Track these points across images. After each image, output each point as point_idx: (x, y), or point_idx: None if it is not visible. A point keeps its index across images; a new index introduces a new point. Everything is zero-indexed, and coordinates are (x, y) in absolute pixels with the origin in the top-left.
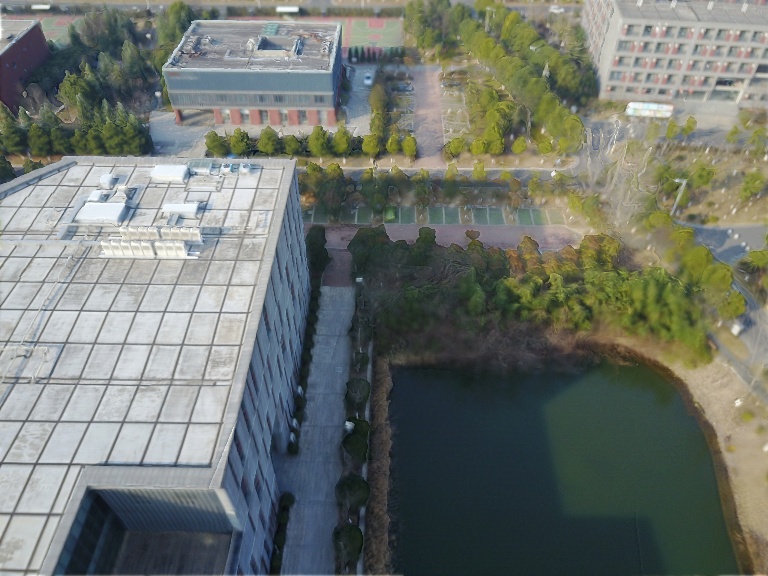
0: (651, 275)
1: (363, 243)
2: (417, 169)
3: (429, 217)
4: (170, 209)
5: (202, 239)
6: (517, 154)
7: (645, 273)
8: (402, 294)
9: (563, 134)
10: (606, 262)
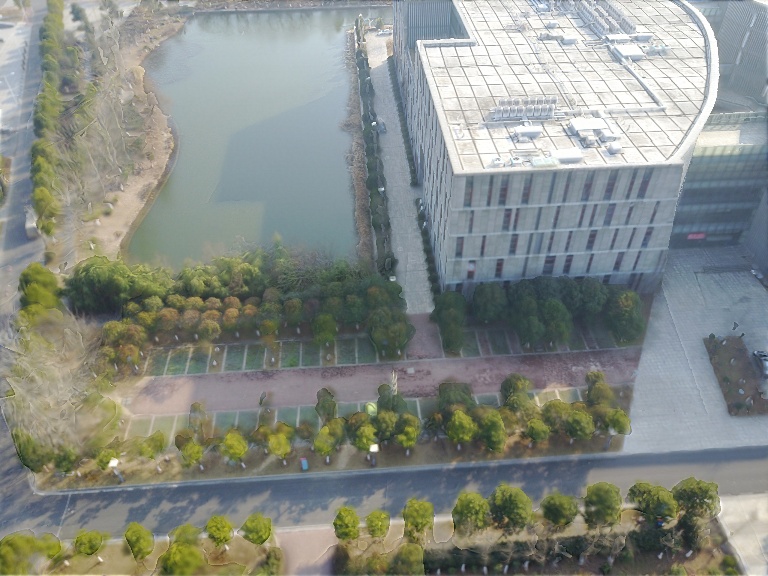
0: (108, 266)
1: None
2: None
3: (319, 418)
4: (535, 127)
5: (495, 118)
6: None
7: (111, 270)
8: None
9: (42, 555)
10: (131, 312)
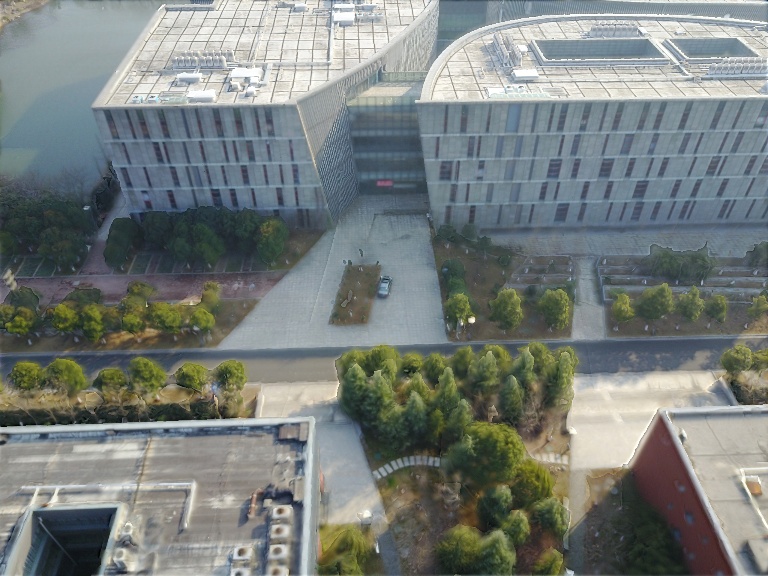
0: None
1: None
2: None
3: None
4: (196, 74)
5: None
6: None
7: None
8: (55, 186)
9: None
10: None
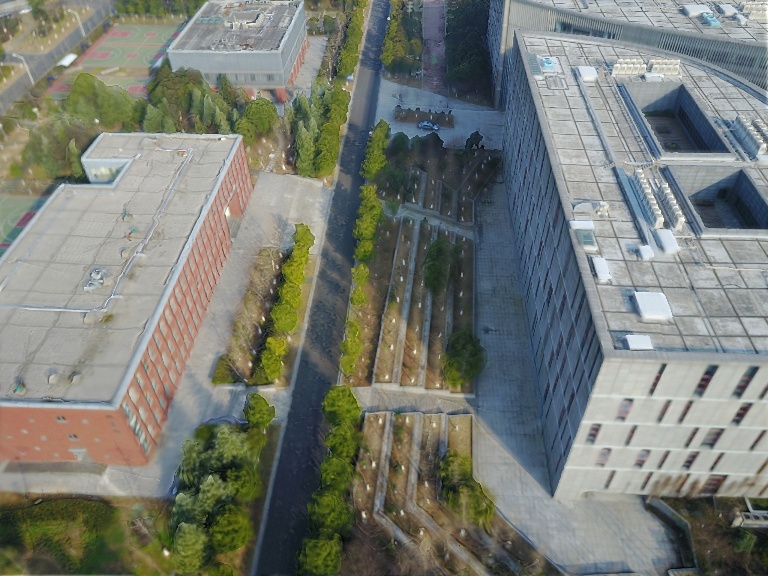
0: None
1: (466, 21)
2: (368, 26)
3: None
4: None
5: None
6: None
7: None
8: None
9: None
10: None
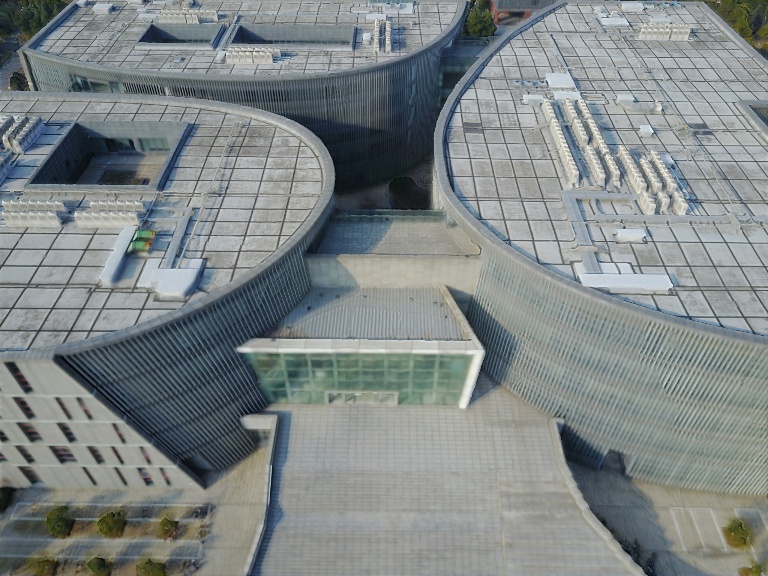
0: None
1: None
2: None
3: None
4: (656, 20)
5: None
6: (758, 39)
7: None
8: None
9: None
10: None
